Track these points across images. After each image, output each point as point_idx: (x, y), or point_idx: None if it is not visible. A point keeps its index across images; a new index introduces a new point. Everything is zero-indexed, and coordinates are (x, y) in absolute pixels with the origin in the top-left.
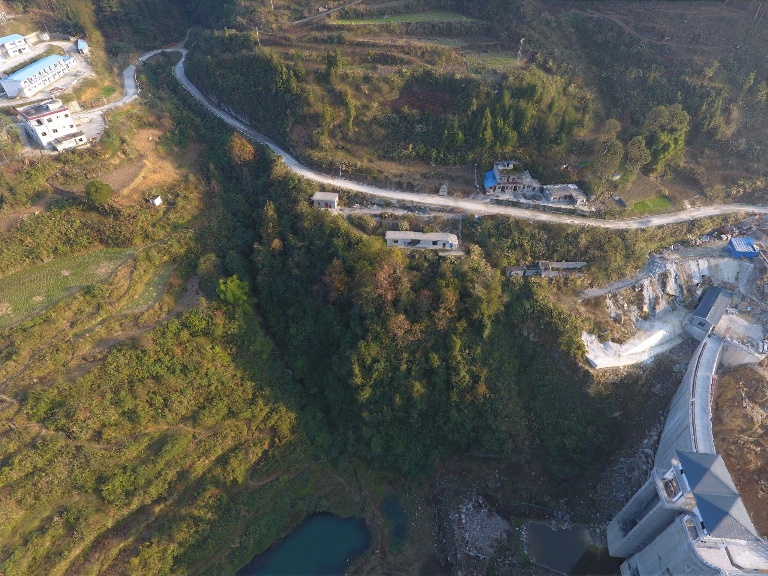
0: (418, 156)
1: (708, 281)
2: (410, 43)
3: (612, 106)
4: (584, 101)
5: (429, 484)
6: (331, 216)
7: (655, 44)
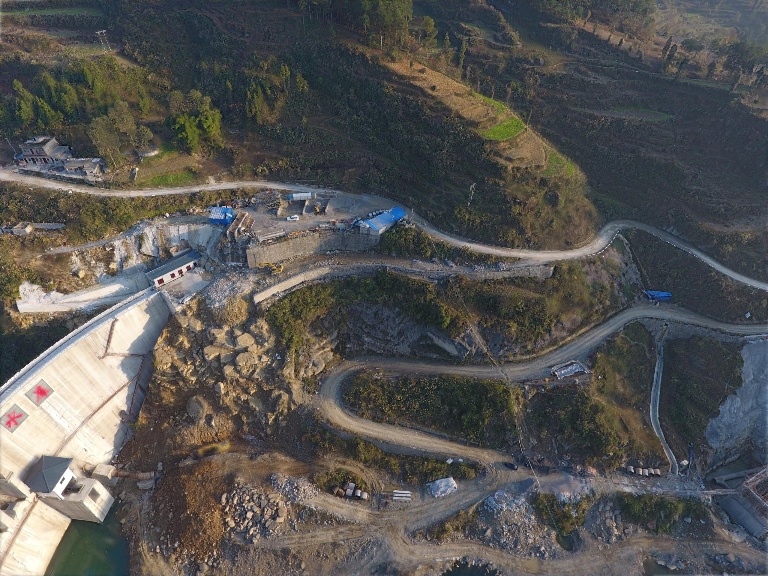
0: None
1: (189, 245)
2: (23, 33)
3: None
4: (164, 88)
5: None
6: None
7: (234, 40)
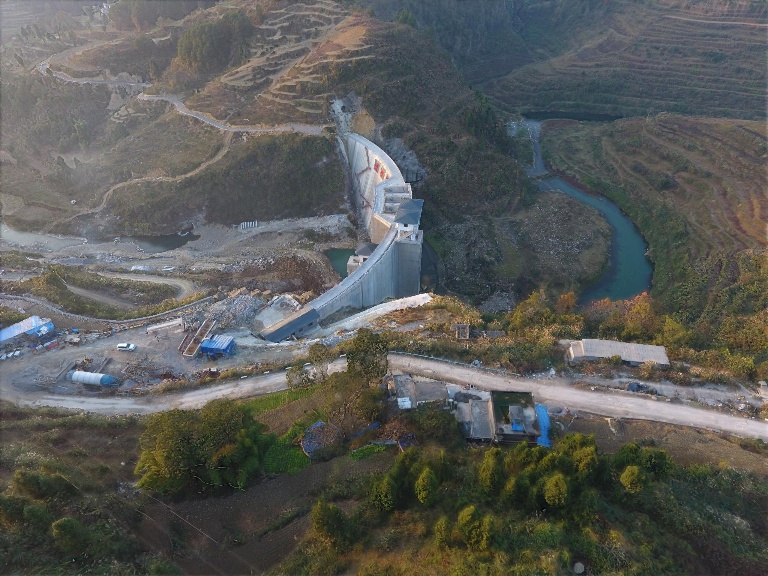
0: None
1: None
2: None
3: None
4: None
5: None
6: (760, 368)
7: None
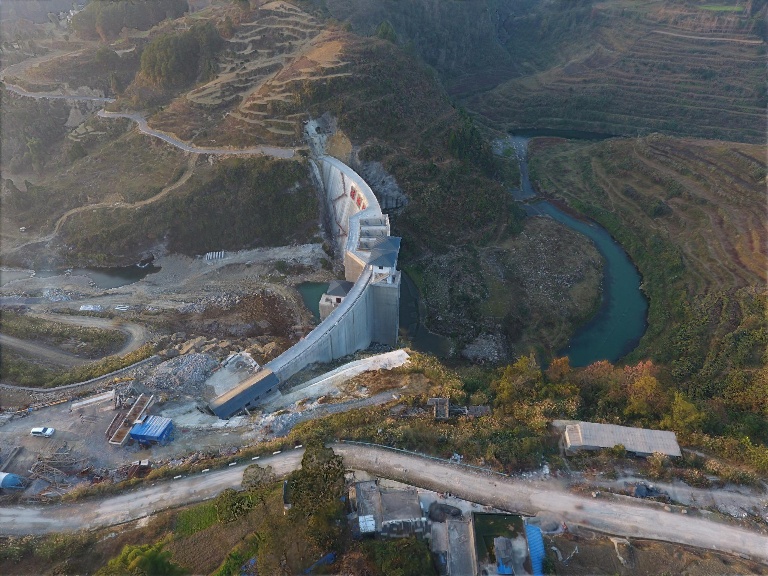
0: None
1: None
2: None
3: None
4: None
5: None
6: None
7: None
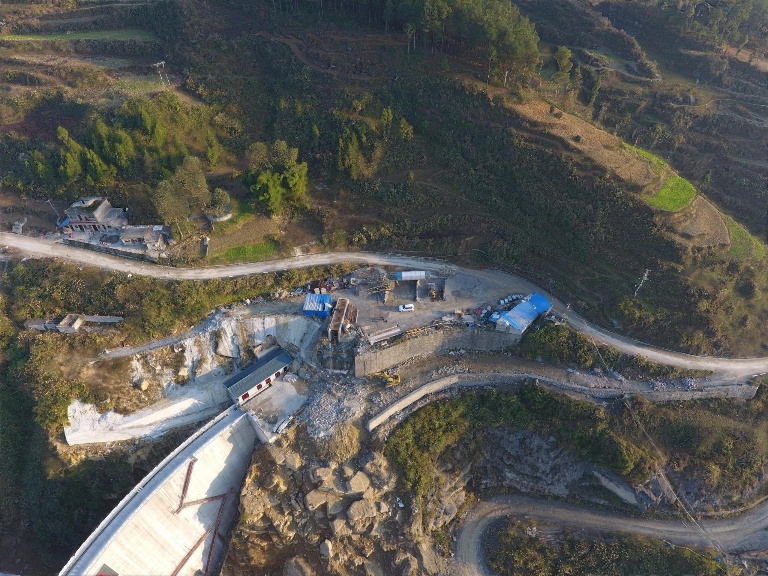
0: (8, 188)
1: (276, 342)
2: (65, 62)
3: (270, 138)
4: (234, 132)
5: None
6: None
7: (318, 72)
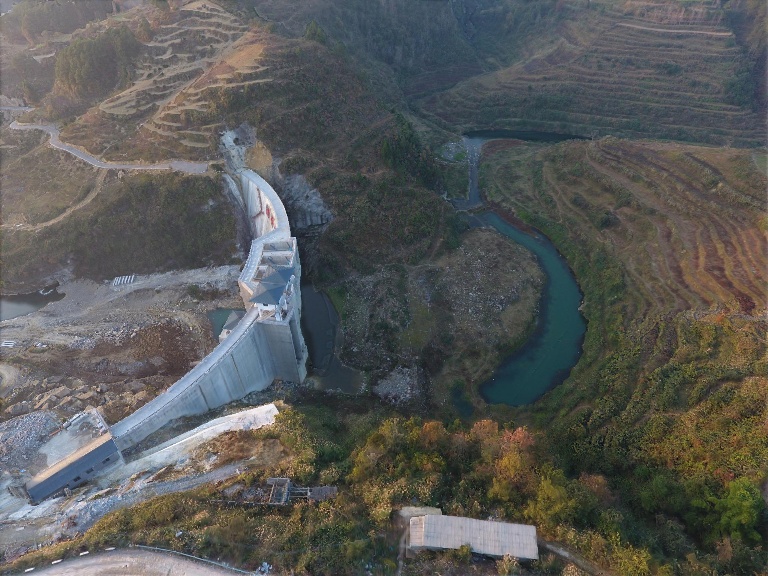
0: None
1: None
2: None
3: None
4: None
5: (435, 416)
6: (656, 575)
7: None
